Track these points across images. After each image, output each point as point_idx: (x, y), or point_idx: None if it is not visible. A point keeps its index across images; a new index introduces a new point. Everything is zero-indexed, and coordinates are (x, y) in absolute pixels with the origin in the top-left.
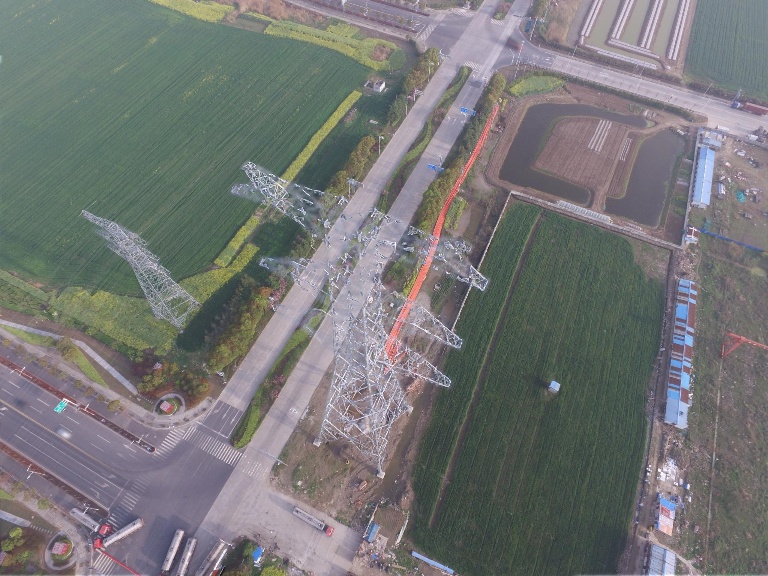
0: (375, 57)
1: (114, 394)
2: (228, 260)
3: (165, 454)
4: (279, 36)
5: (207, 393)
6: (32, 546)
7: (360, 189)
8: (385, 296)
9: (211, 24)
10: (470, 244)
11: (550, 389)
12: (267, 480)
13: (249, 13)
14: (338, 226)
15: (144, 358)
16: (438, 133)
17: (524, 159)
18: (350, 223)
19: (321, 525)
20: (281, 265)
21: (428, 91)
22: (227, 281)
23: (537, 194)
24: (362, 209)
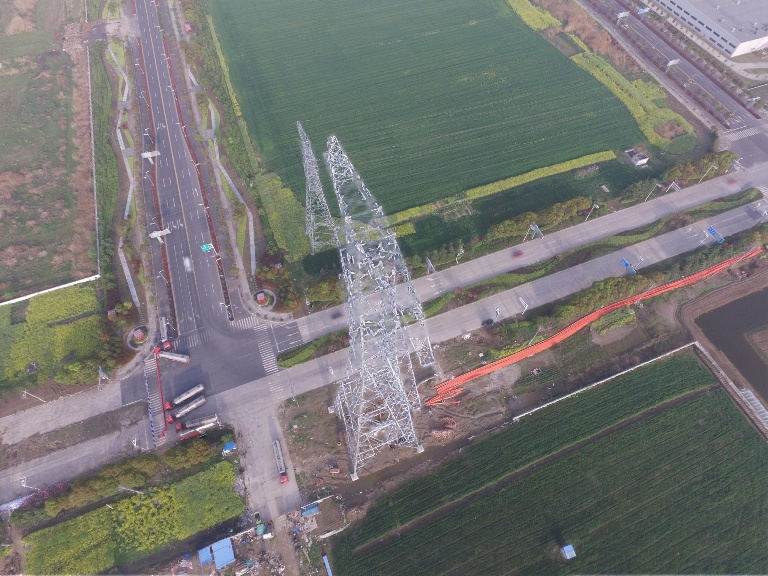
0: (660, 130)
1: (241, 264)
2: (386, 225)
3: (236, 329)
4: (581, 67)
5: (293, 310)
6: (129, 320)
7: (540, 239)
8: (482, 343)
9: (530, 30)
10: (603, 359)
11: (562, 550)
12: (278, 404)
13: (571, 35)
14: (493, 257)
15: (275, 254)
16: (664, 237)
17: (744, 321)
18: (505, 262)
19: (282, 469)
20: (418, 256)
21: (690, 191)
22: (372, 240)
23: (726, 365)
24: (526, 257)
